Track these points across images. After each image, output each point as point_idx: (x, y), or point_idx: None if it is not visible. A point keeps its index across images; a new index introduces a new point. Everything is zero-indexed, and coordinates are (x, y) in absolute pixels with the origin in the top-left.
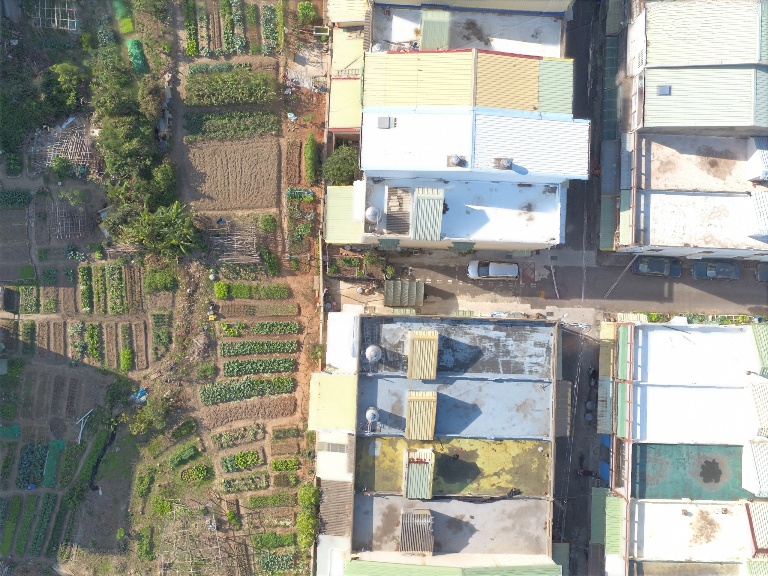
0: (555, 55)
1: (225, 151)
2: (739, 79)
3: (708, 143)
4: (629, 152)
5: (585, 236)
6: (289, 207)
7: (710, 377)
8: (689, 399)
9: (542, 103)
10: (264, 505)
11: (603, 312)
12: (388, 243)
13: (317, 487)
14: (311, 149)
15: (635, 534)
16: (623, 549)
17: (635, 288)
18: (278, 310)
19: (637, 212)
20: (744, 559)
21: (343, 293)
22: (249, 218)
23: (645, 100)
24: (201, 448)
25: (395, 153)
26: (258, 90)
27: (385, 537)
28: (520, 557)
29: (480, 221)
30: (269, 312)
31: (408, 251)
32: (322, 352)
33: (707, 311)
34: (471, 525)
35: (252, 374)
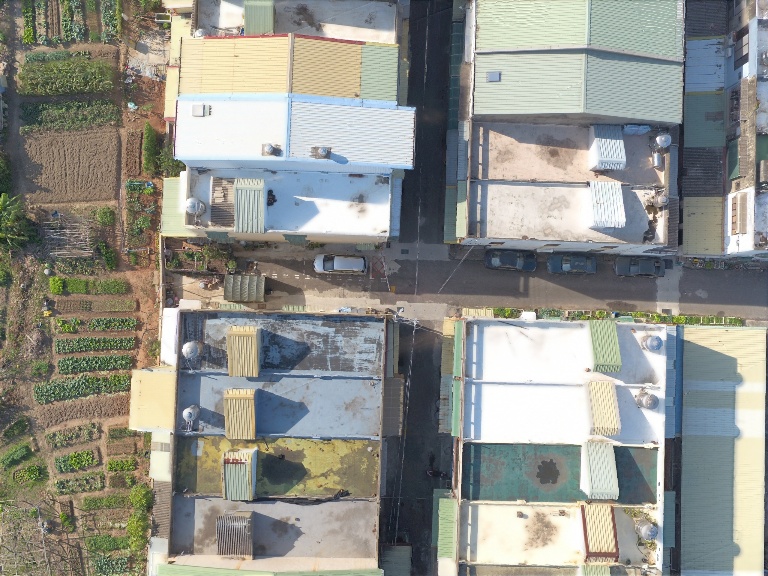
0: (389, 41)
1: (63, 142)
2: (569, 64)
3: (548, 132)
4: (466, 141)
5: (418, 228)
6: (128, 199)
7: (548, 374)
8: (526, 397)
9: (365, 90)
10: (98, 507)
11: (456, 307)
12: (216, 236)
13: (153, 488)
14: (147, 139)
15: (468, 537)
16: (455, 552)
17: (489, 283)
18: (116, 306)
19: (473, 203)
20: (581, 563)
21: (186, 288)
22: (87, 211)
23: (475, 87)
24: (34, 448)
25: (208, 142)
26: (93, 79)
27: (207, 540)
28: (345, 561)
29: (309, 213)
30: (106, 308)
31: (253, 245)
32: (160, 349)
33: (564, 306)
34: (297, 528)
35: (88, 372)
